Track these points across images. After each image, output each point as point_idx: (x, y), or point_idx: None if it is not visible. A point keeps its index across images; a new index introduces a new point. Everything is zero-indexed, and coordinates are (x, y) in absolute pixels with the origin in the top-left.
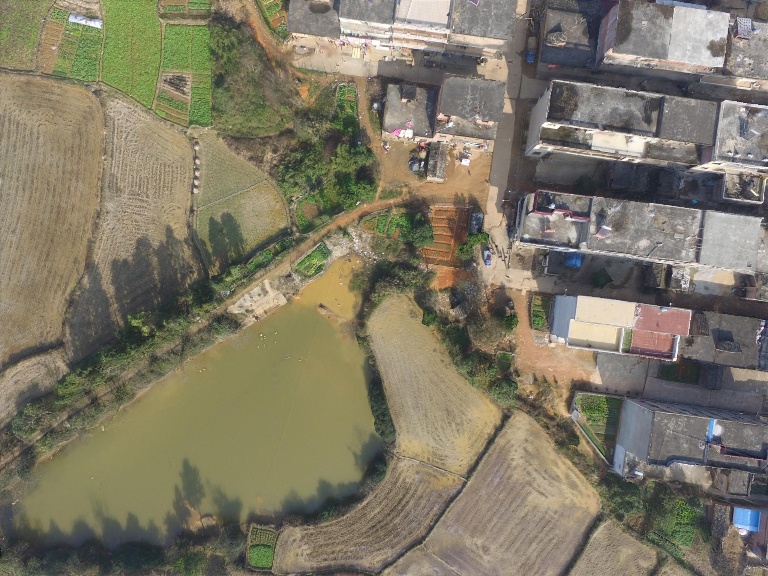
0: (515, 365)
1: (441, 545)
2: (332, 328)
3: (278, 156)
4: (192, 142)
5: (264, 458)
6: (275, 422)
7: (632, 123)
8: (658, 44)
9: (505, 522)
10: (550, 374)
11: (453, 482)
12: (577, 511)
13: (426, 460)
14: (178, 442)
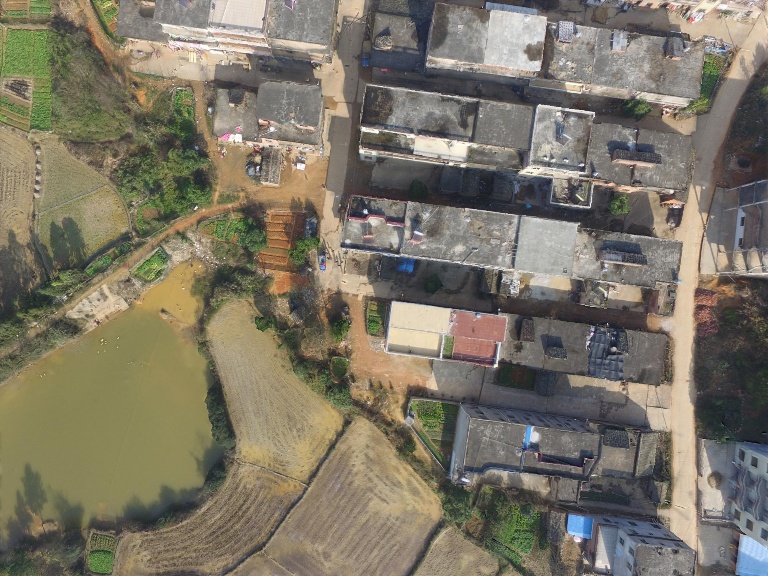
0: (351, 371)
1: (282, 551)
2: (174, 333)
3: (118, 161)
4: (34, 147)
5: (106, 463)
6: (117, 427)
7: (448, 128)
8: (474, 48)
9: (346, 528)
10: (386, 380)
11: (294, 488)
12: (419, 517)
13: (267, 466)
14: (20, 447)
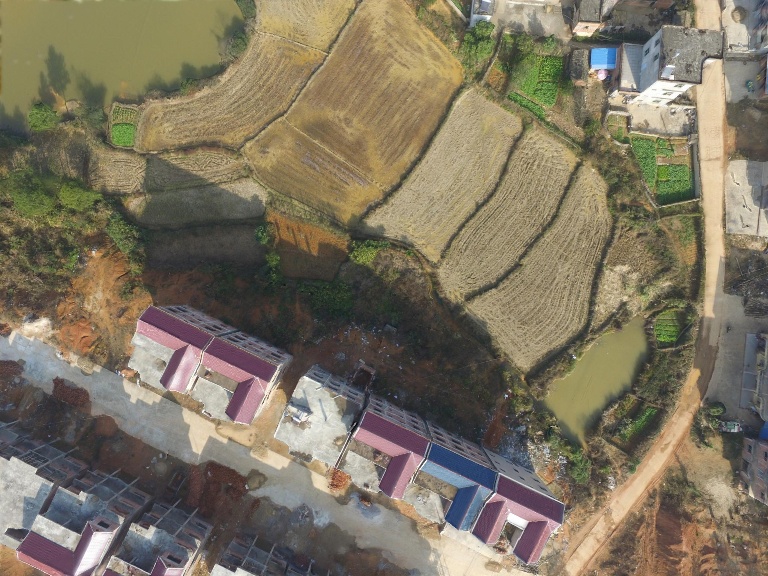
0: None
1: (303, 118)
2: None
3: None
4: None
5: (128, 43)
6: (139, 7)
7: None
8: None
9: (367, 94)
10: None
11: (314, 57)
12: (440, 82)
13: (287, 36)
14: (44, 29)
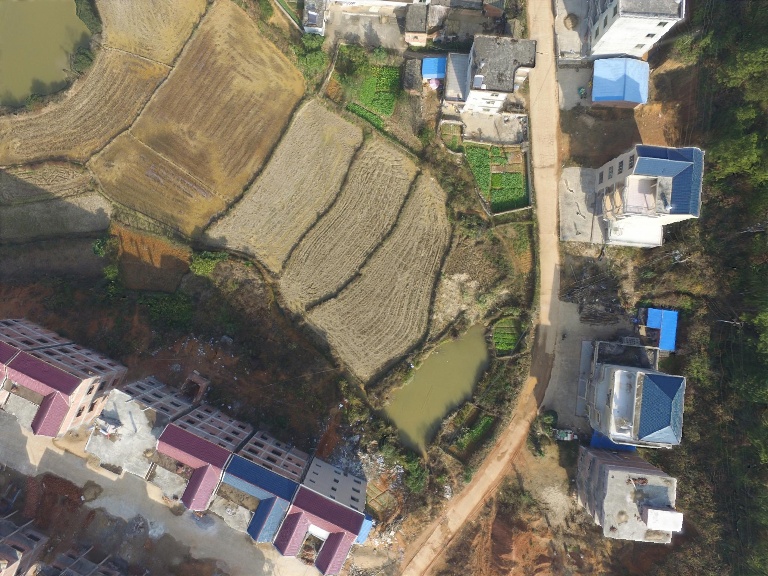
0: None
1: (148, 132)
2: None
3: None
4: None
5: None
6: None
7: None
8: None
9: (211, 107)
10: None
11: (159, 71)
12: (282, 94)
13: (133, 51)
14: None
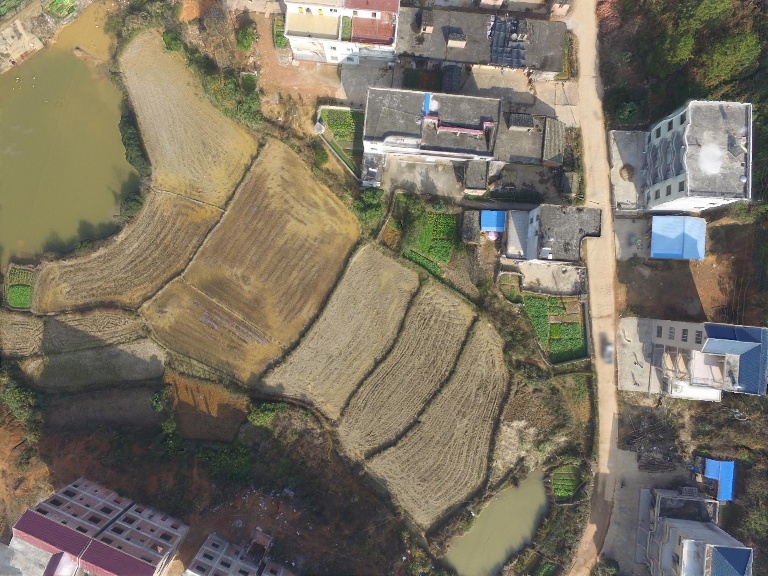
0: (260, 86)
1: (200, 277)
2: (89, 70)
3: None
4: None
5: (24, 201)
6: (34, 164)
7: None
8: None
9: (264, 251)
10: (295, 92)
11: (211, 214)
12: (337, 237)
13: (183, 193)
14: None
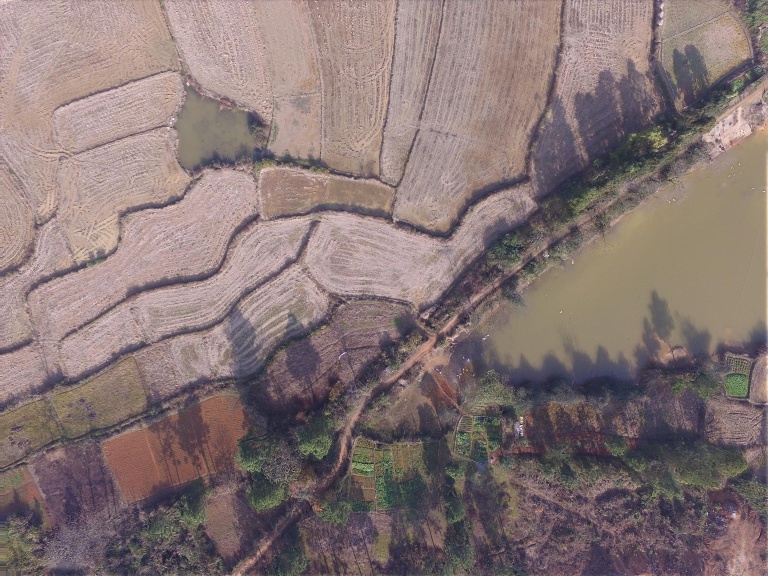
0: None
1: None
2: None
3: None
4: None
5: (732, 289)
6: (743, 252)
7: None
8: None
9: None
10: None
11: None
12: None
13: None
14: (647, 274)
